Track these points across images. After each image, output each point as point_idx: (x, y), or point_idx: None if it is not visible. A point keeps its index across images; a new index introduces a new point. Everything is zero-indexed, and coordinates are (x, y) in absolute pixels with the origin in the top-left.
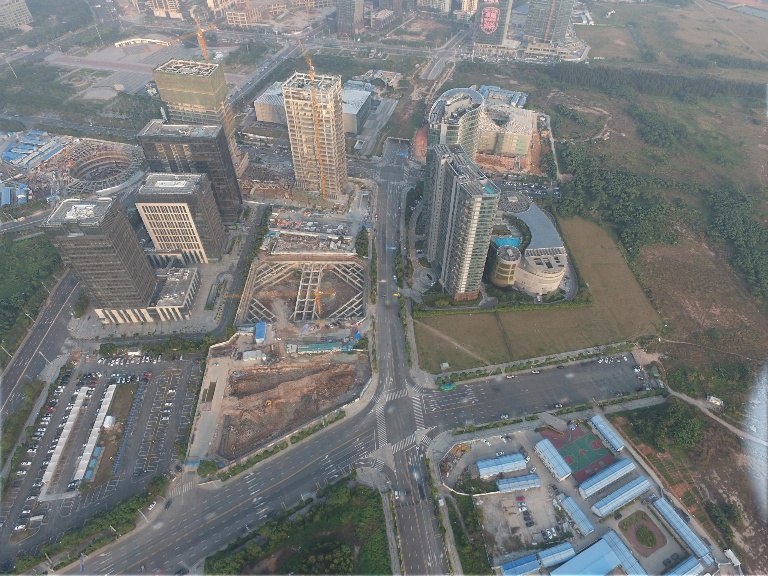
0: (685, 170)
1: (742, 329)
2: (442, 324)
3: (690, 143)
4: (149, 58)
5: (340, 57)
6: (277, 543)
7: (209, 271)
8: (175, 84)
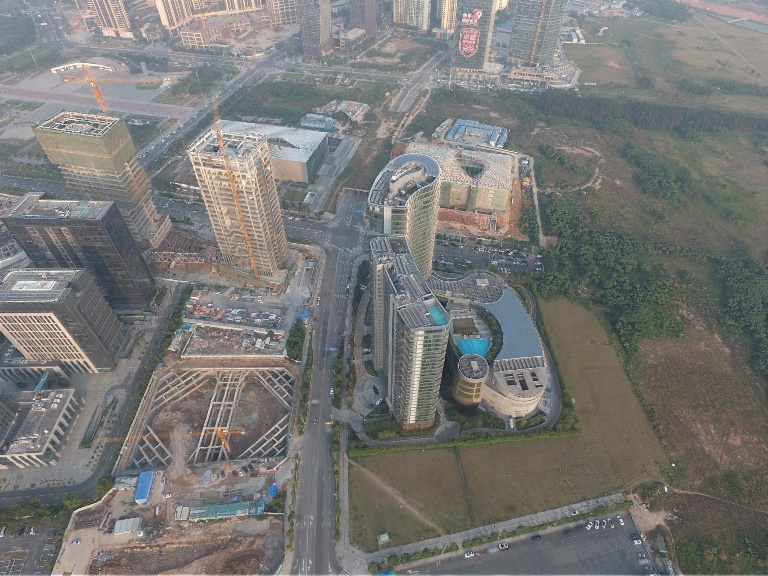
0: (690, 229)
1: None
2: (385, 467)
3: (694, 193)
4: (87, 86)
5: (301, 85)
6: None
7: (97, 385)
8: (62, 145)
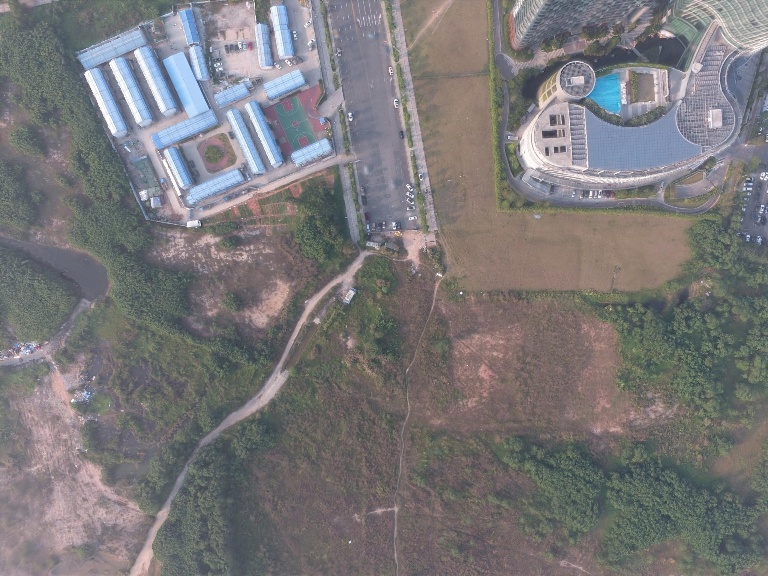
0: None
1: (452, 389)
2: None
3: None
4: None
5: None
6: None
7: None
8: None
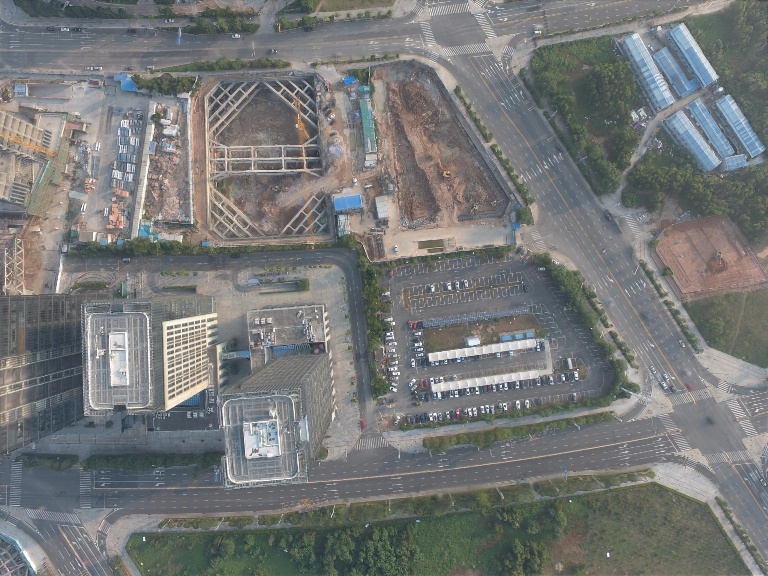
0: None
1: None
2: None
3: None
4: None
5: None
6: None
7: (233, 307)
8: None
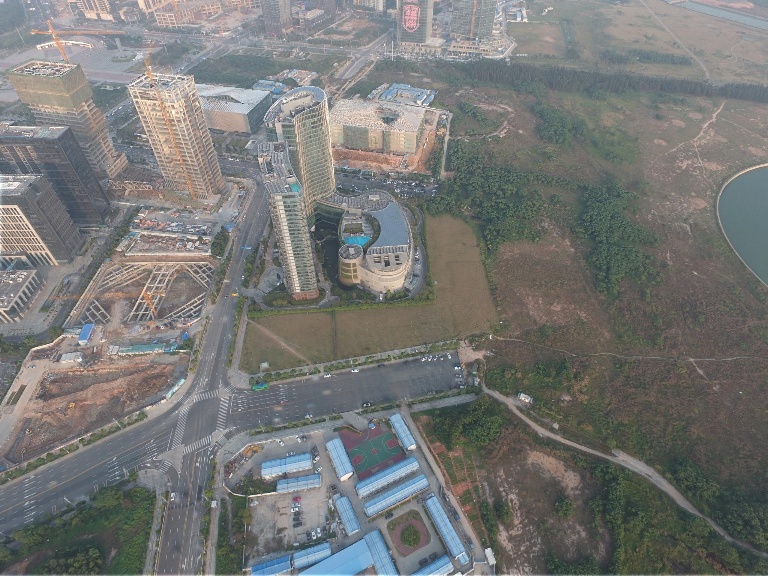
0: (572, 166)
1: (577, 325)
2: (275, 324)
3: (585, 139)
4: None
5: (259, 57)
6: (31, 547)
7: (57, 273)
8: (30, 85)
